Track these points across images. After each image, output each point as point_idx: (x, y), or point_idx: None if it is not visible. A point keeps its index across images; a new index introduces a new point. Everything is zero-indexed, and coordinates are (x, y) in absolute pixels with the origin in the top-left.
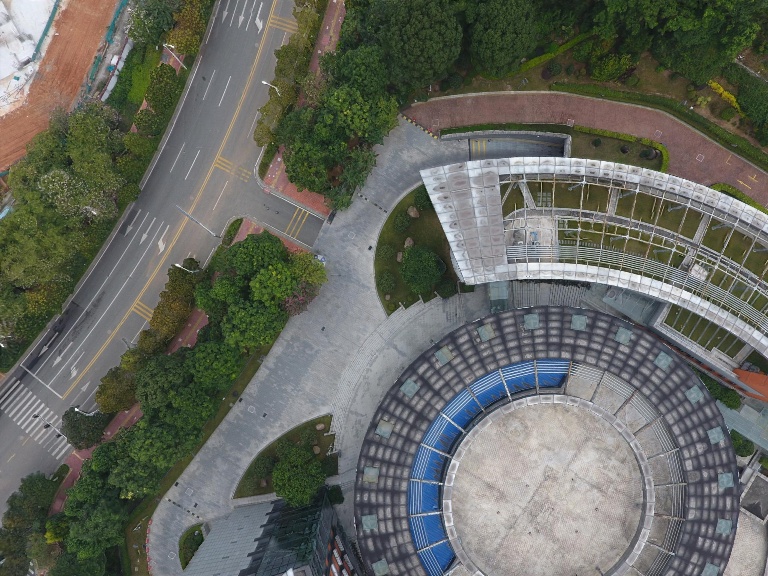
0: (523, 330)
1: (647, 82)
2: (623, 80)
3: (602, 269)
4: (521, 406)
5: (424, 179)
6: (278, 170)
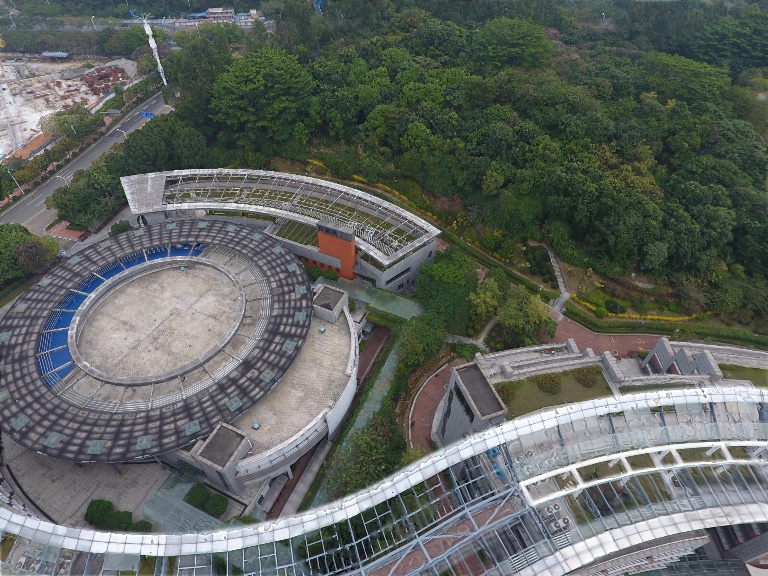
0: (165, 231)
1: (282, 168)
2: (267, 167)
3: (221, 203)
4: (152, 263)
5: (121, 180)
6: (60, 227)
